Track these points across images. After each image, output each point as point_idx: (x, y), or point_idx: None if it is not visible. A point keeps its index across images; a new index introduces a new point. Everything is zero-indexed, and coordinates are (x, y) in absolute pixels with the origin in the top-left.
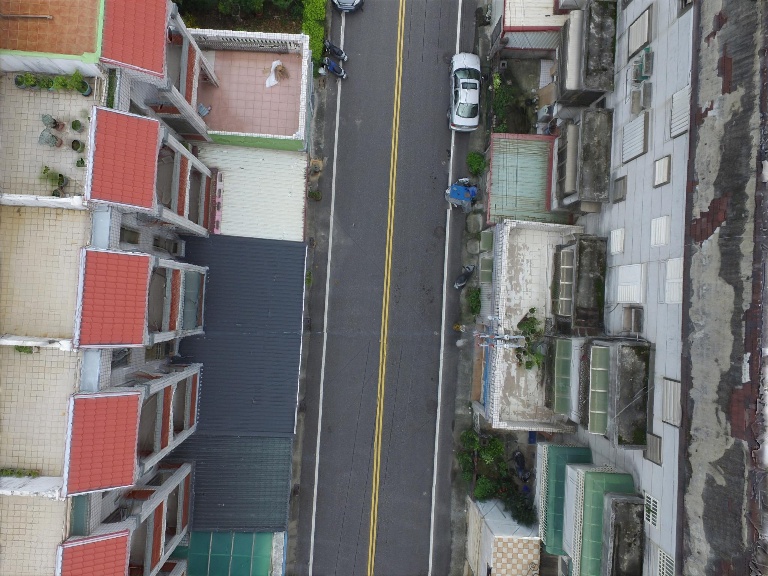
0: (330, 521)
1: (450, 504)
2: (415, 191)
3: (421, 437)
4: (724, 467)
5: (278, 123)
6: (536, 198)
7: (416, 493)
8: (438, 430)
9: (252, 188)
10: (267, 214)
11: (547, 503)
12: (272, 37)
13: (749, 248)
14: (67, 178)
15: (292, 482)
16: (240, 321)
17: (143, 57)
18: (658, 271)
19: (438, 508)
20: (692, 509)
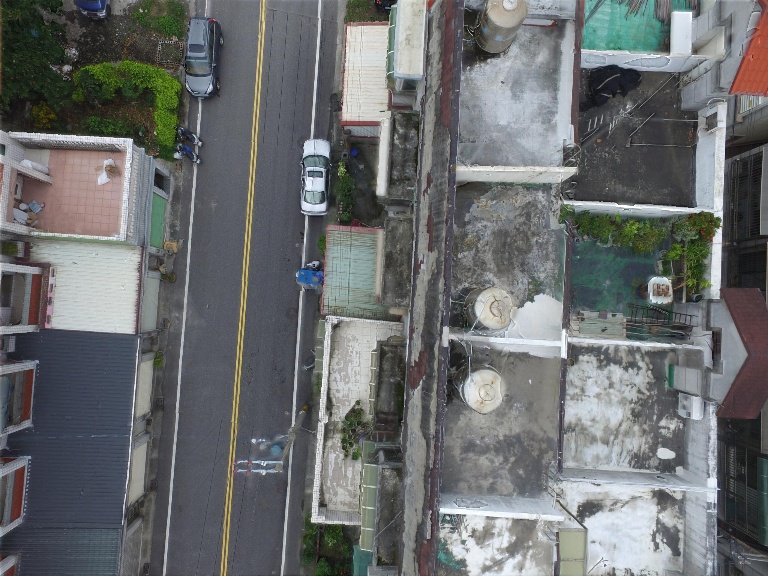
0: None
1: None
2: (268, 273)
3: (270, 516)
4: None
5: (110, 220)
6: (368, 290)
7: (265, 572)
8: (288, 509)
9: (85, 282)
10: (99, 308)
11: None
12: (96, 141)
13: (434, 408)
14: None
15: (142, 561)
16: (70, 413)
17: None
18: None
19: None
20: None
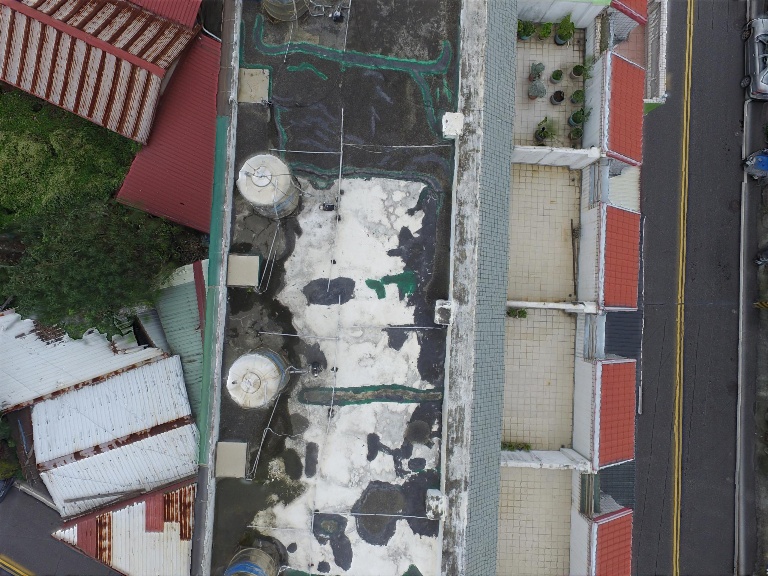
0: None
1: (754, 490)
2: (708, 163)
3: (722, 420)
4: None
5: None
6: None
7: (719, 478)
8: (739, 412)
9: None
10: None
11: None
12: None
13: None
14: (543, 132)
15: None
16: None
17: (636, 1)
18: None
19: (742, 494)
20: None
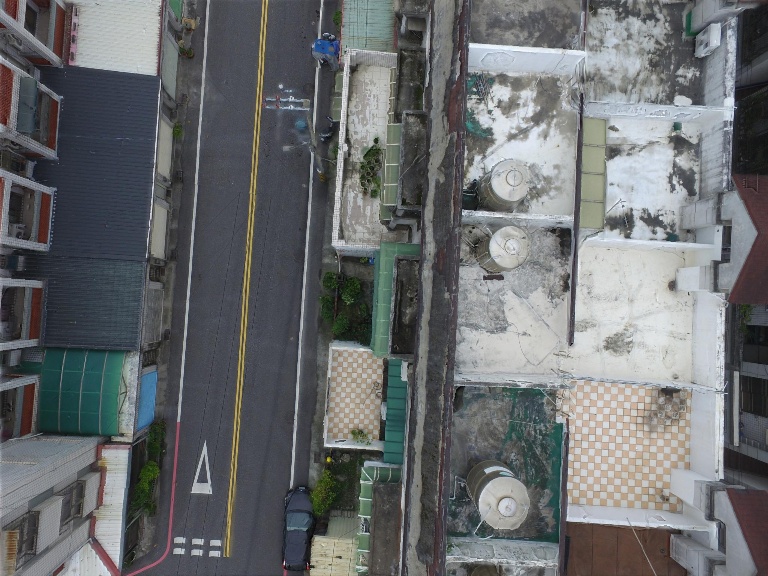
0: (200, 364)
1: (316, 349)
2: (285, 49)
3: (289, 284)
4: (444, 165)
5: None
6: (385, 38)
7: (283, 338)
8: (305, 278)
9: (107, 23)
10: (121, 48)
11: None
12: None
13: None
14: None
15: (163, 327)
16: (94, 149)
17: None
18: None
19: (305, 353)
20: (428, 218)
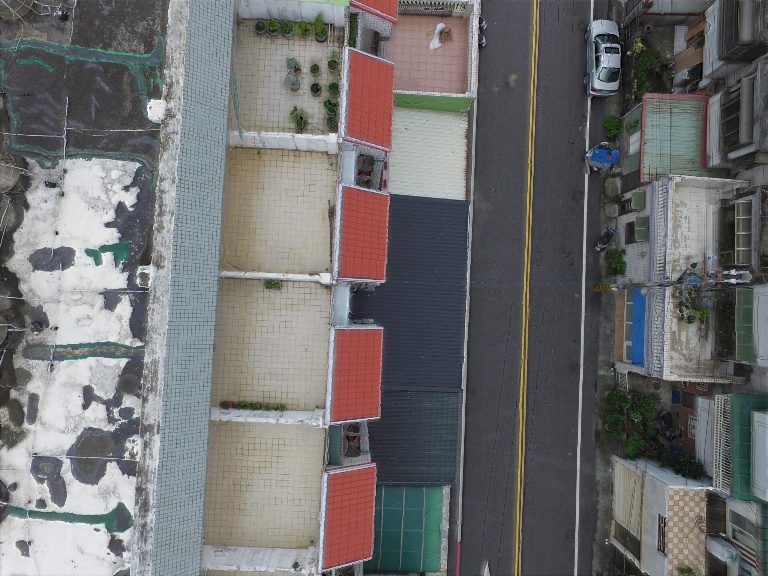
0: (477, 482)
1: (595, 464)
2: (553, 156)
3: (565, 398)
4: None
5: (442, 84)
6: (691, 156)
7: (561, 453)
8: (581, 391)
9: (416, 148)
10: (431, 173)
11: (729, 450)
12: None
13: None
14: (304, 121)
15: None
16: (408, 278)
17: (382, 2)
18: None
19: (583, 468)
20: None
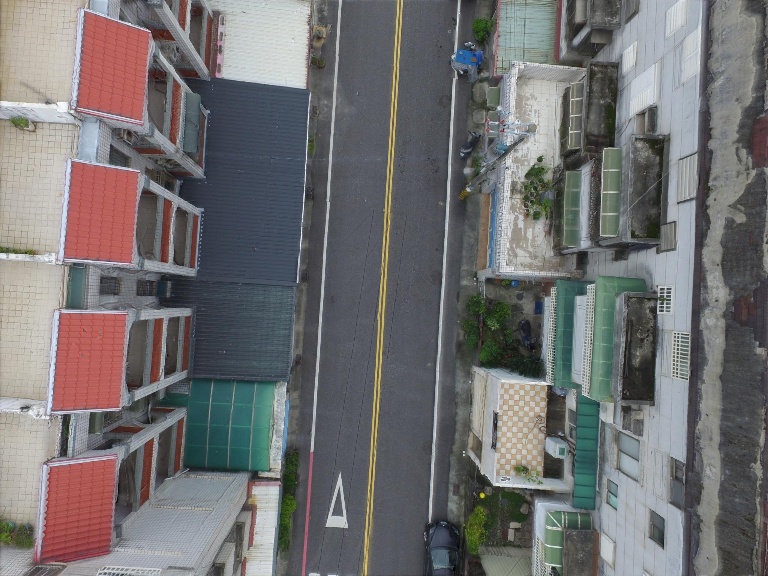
0: (333, 391)
1: (455, 375)
2: (420, 59)
3: (425, 308)
4: (744, 203)
5: None
6: (544, 49)
7: (420, 364)
8: (443, 301)
9: (254, 33)
10: (270, 60)
11: (555, 339)
12: None
13: None
14: None
15: (294, 352)
16: (242, 167)
17: None
18: (673, 58)
19: (442, 379)
20: (710, 260)
